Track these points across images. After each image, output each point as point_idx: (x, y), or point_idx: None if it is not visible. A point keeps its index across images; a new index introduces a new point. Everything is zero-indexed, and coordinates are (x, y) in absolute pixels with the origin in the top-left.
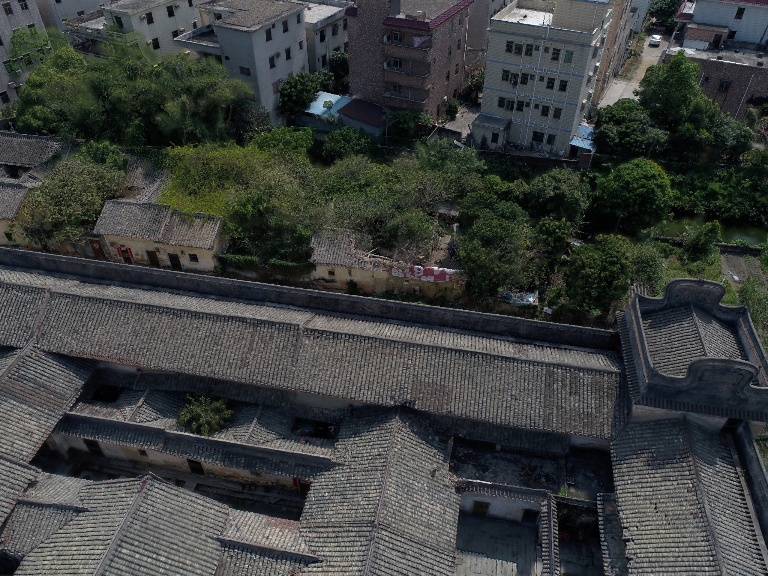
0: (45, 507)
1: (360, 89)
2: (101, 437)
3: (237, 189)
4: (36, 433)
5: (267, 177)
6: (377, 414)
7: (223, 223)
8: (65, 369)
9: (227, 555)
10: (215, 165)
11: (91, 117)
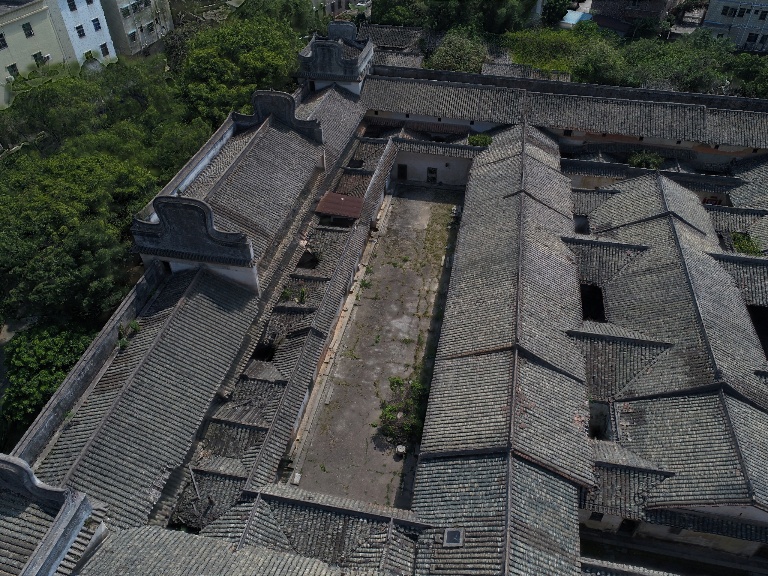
0: (590, 192)
1: (601, 6)
2: (583, 173)
3: (568, 58)
4: (555, 164)
5: (599, 46)
6: (758, 160)
7: (571, 77)
8: (547, 137)
9: (710, 214)
10: (547, 43)
11: (444, 12)
